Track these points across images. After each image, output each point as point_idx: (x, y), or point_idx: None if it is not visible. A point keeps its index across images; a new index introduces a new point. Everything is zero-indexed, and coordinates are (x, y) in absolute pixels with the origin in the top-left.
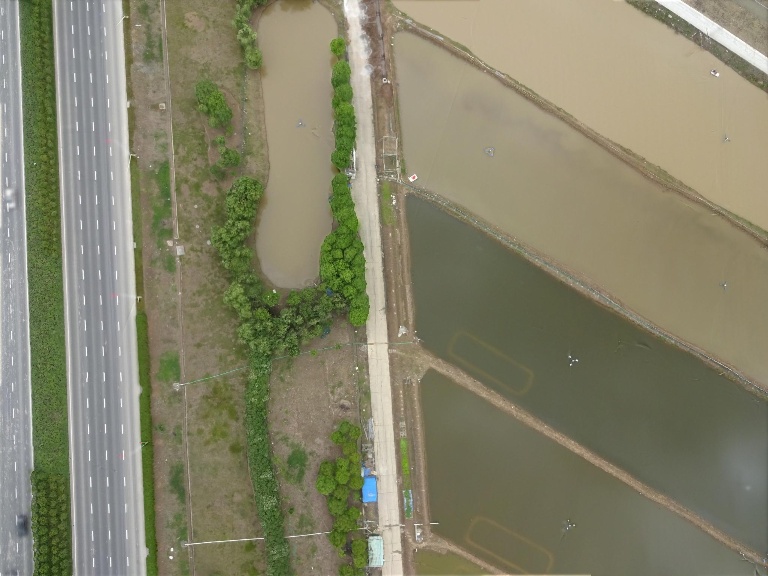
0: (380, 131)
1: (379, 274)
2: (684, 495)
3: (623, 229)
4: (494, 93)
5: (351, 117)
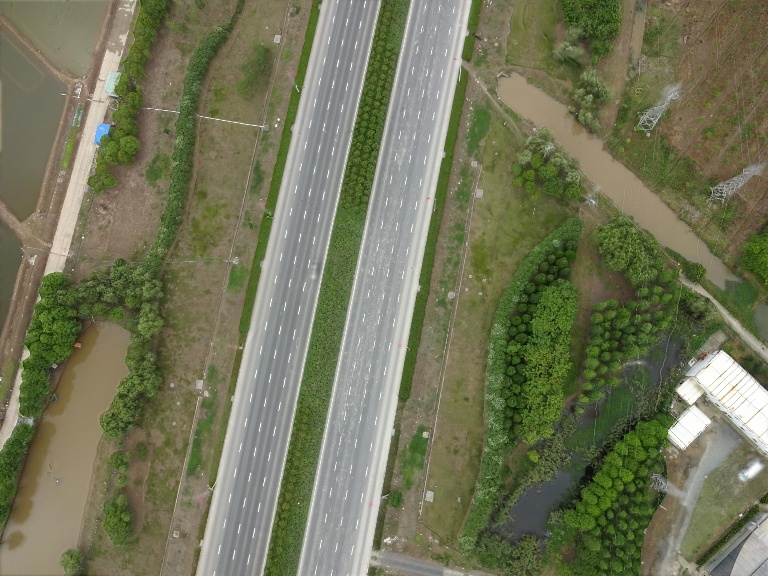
0: None
1: None
2: None
3: None
4: None
5: None
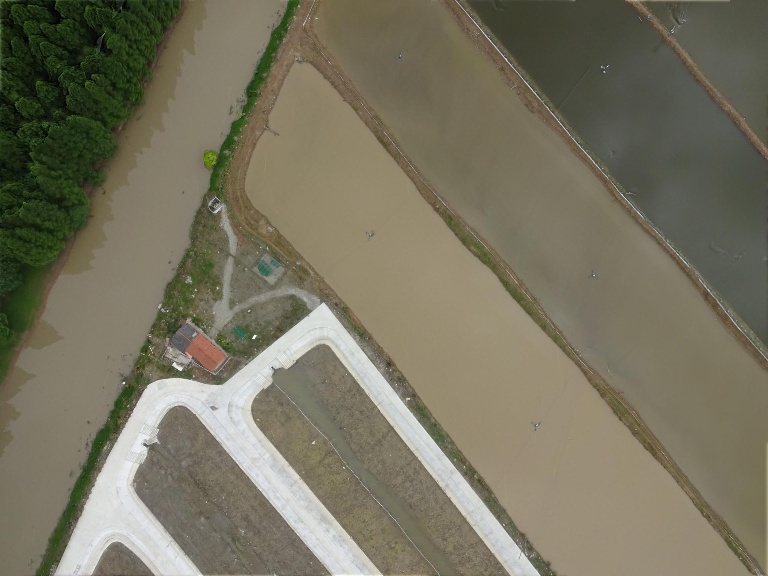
0: None
1: None
2: (706, 101)
3: (679, 368)
4: None
5: None
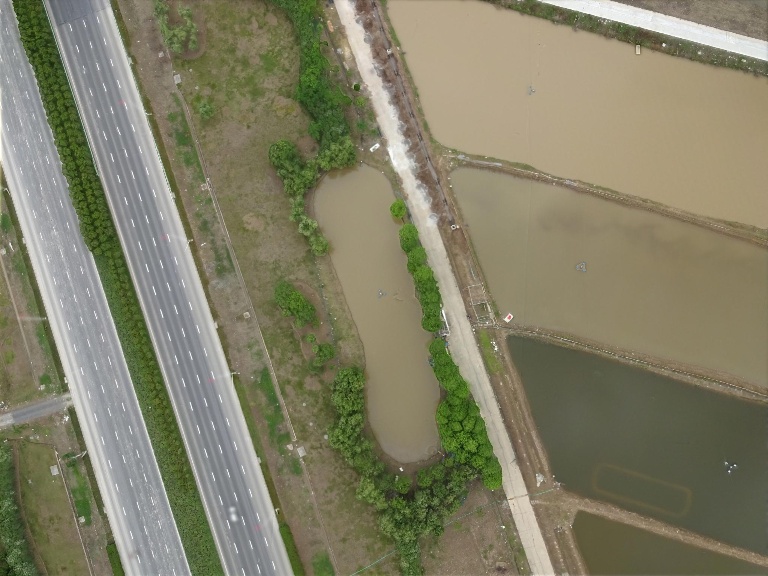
0: (462, 279)
1: (500, 426)
2: None
3: (750, 310)
4: (569, 204)
5: (431, 280)
